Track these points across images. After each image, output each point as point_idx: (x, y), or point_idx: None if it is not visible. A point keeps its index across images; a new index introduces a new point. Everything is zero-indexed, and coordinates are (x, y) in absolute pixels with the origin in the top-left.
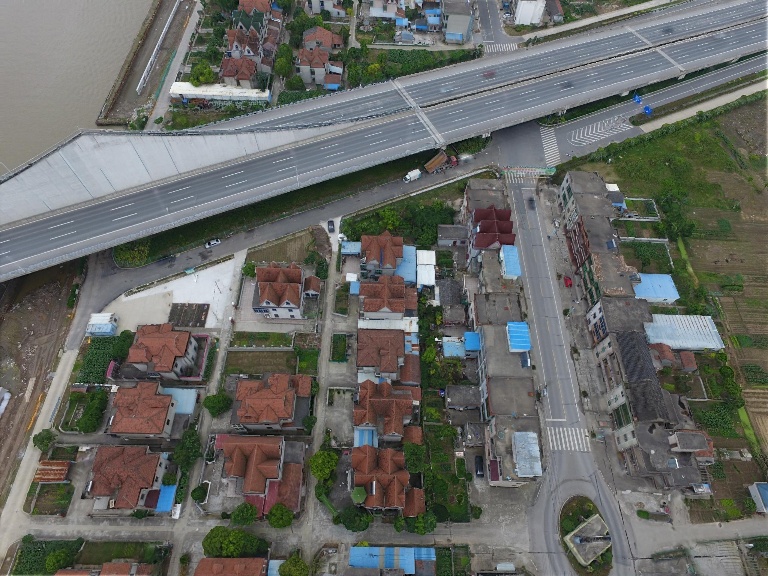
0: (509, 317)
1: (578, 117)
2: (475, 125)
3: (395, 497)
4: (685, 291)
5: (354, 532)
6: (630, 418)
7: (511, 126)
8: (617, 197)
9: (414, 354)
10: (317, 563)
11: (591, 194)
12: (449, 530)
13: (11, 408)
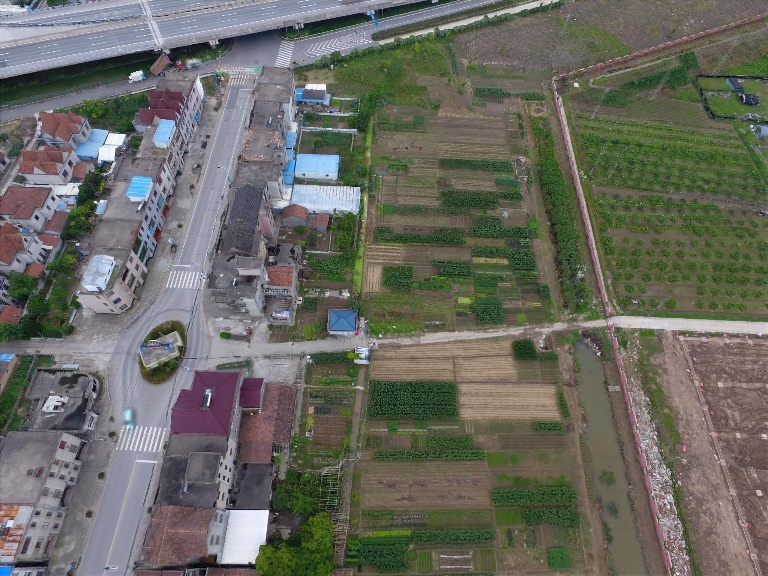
0: (146, 176)
1: (321, 33)
2: (201, 32)
3: None
4: (346, 168)
5: None
6: None
7: (241, 35)
8: (318, 94)
9: (65, 211)
10: None
11: (275, 84)
12: (42, 344)
13: None
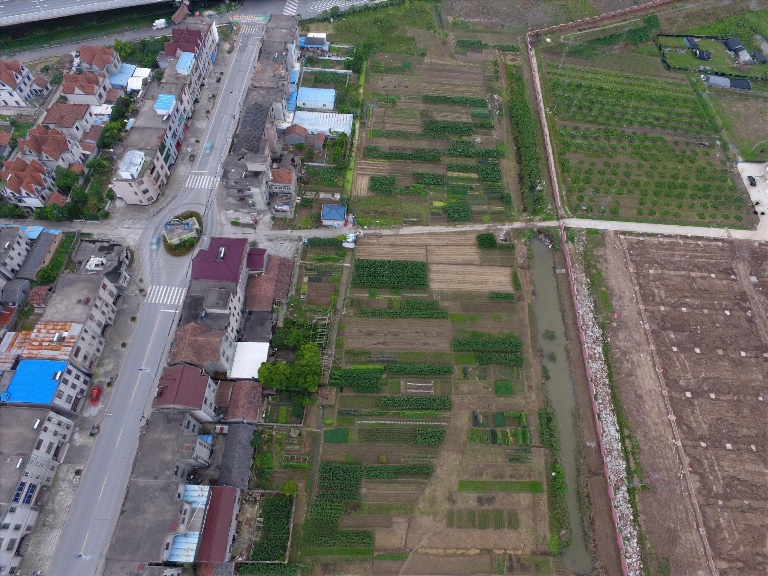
0: None
1: None
2: None
3: (23, 183)
4: (341, 99)
5: (10, 223)
6: None
7: None
8: (319, 40)
9: None
10: None
11: (281, 29)
12: (83, 225)
13: None
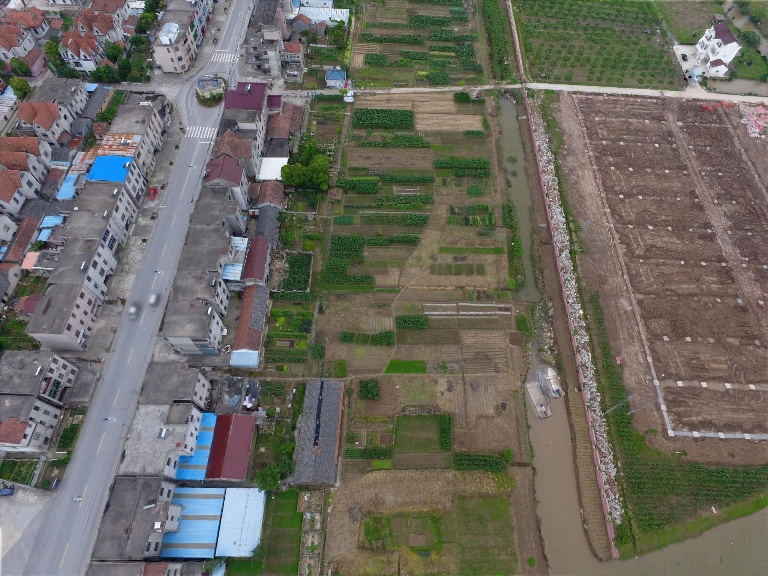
0: None
1: None
2: None
3: (81, 46)
4: None
5: None
6: None
7: None
8: None
9: (136, 16)
10: None
11: None
12: (129, 87)
13: None
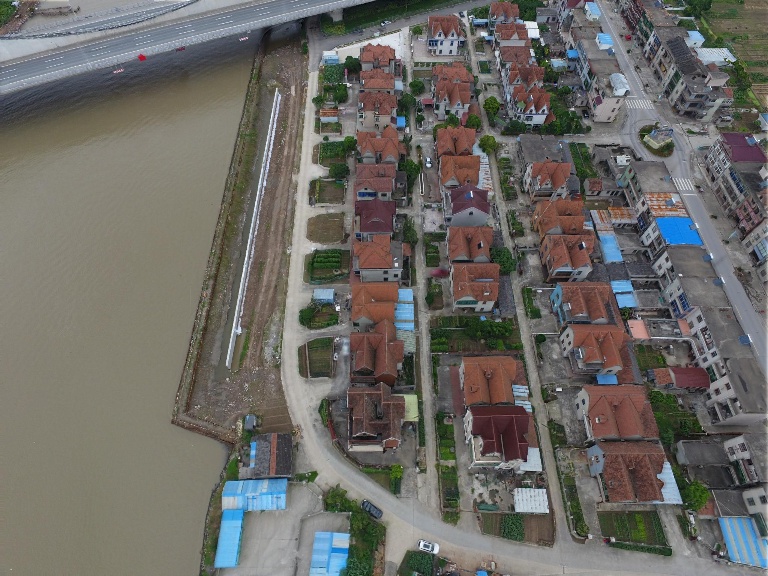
0: (596, 36)
1: None
2: None
3: None
4: (708, 38)
5: (515, 139)
6: (680, 74)
7: None
8: None
9: (535, 65)
10: (497, 149)
11: None
12: (572, 138)
13: (284, 100)
